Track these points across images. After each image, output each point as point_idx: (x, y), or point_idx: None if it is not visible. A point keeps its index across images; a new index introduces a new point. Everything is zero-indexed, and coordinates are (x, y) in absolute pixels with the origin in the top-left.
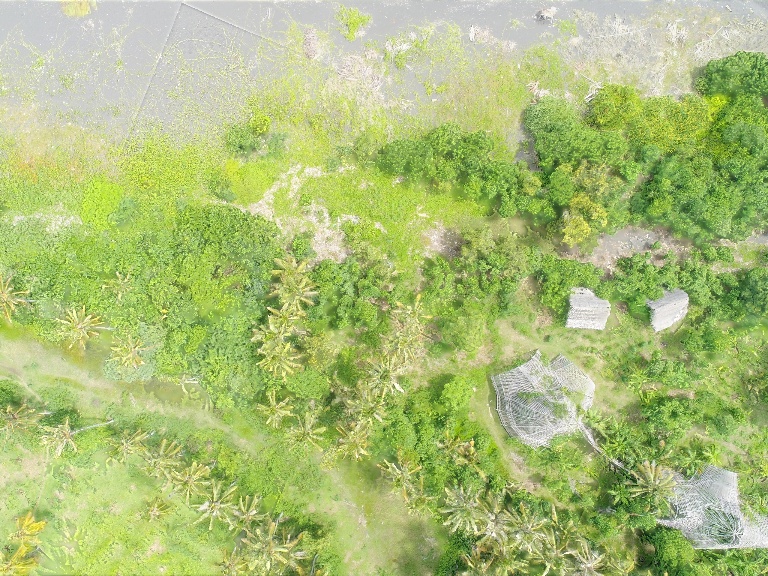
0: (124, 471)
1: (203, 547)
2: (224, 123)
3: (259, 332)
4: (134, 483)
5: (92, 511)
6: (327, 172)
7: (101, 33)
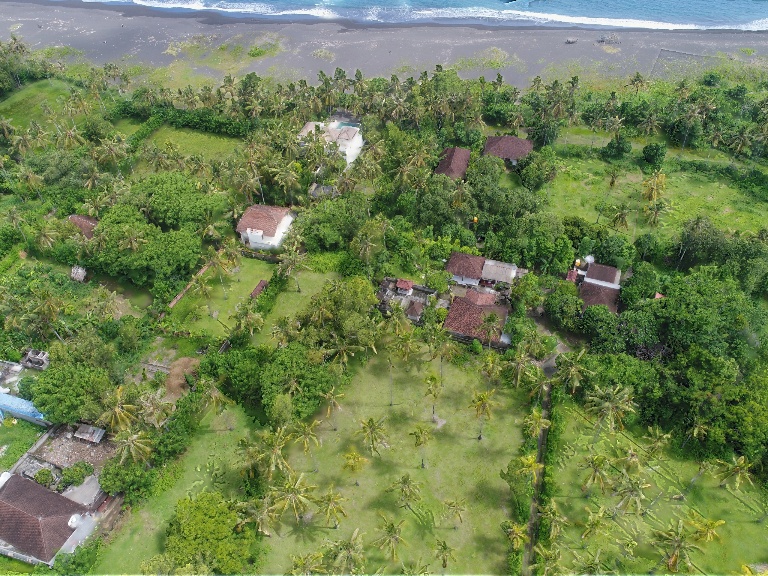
0: (692, 180)
1: (760, 211)
2: (695, 78)
3: (767, 109)
4: (701, 185)
5: (679, 194)
6: (756, 92)
7: (625, 56)
